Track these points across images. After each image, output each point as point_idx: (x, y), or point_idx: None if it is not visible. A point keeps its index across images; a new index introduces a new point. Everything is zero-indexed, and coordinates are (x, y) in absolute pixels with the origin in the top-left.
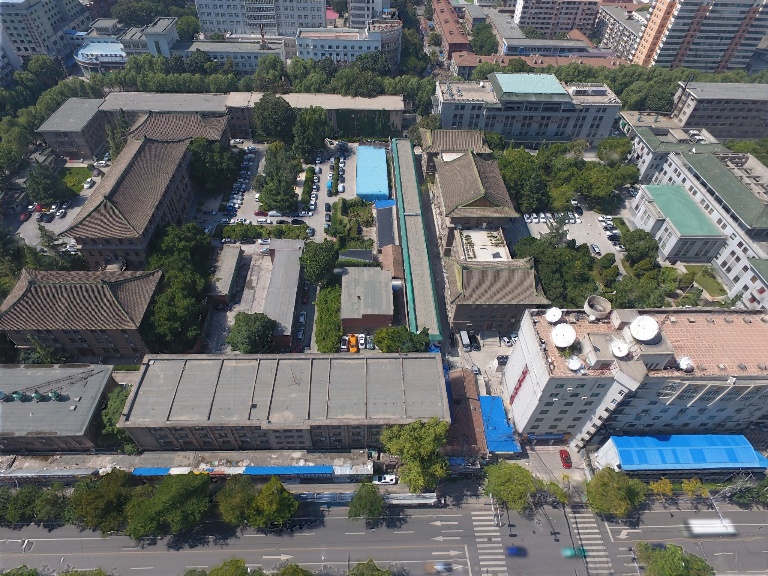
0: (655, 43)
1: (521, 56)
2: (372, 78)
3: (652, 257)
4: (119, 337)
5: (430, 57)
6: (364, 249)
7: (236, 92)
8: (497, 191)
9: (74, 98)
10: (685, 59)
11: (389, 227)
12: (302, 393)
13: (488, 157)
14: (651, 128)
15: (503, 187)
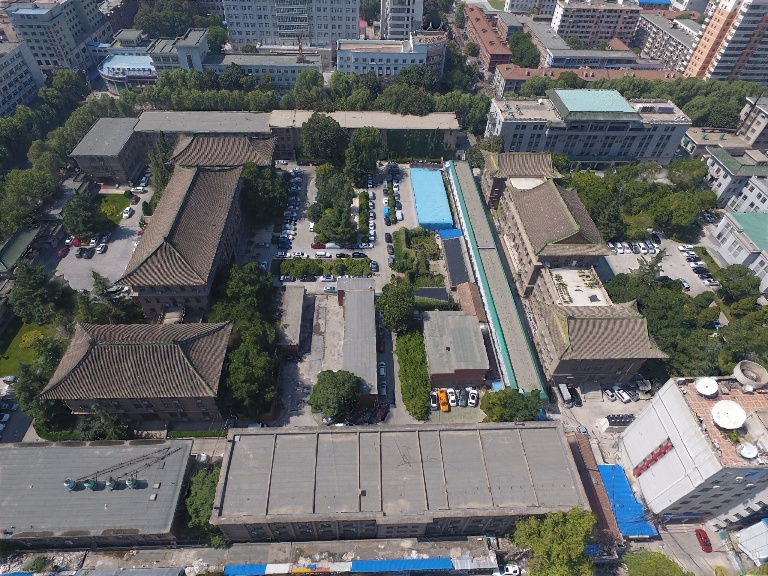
0: (711, 55)
1: (571, 69)
2: (423, 95)
3: (754, 296)
4: (190, 402)
5: None
6: (436, 287)
7: (278, 110)
8: (586, 225)
9: (106, 118)
10: (742, 71)
11: (460, 261)
12: (415, 475)
13: (557, 181)
14: (727, 149)
15: (590, 219)
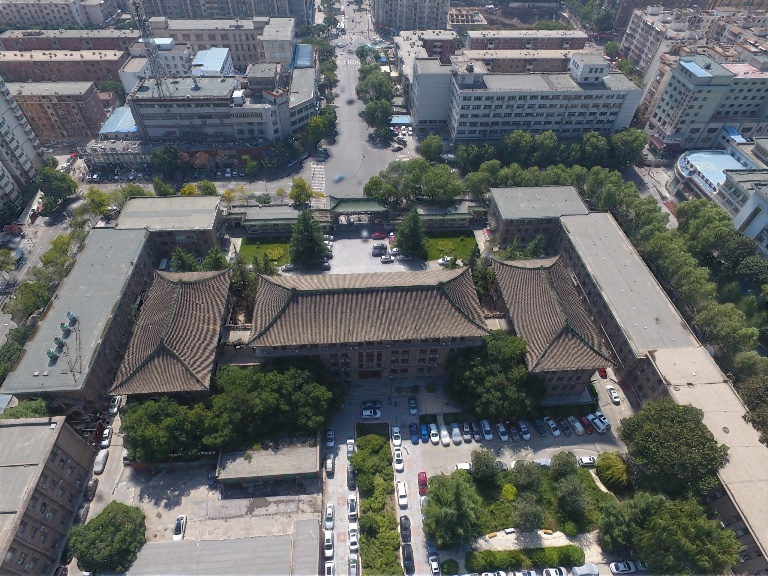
0: None
1: None
2: None
3: None
4: None
5: None
6: None
7: None
8: None
9: (575, 189)
10: None
11: None
12: None
13: None
14: None
15: None
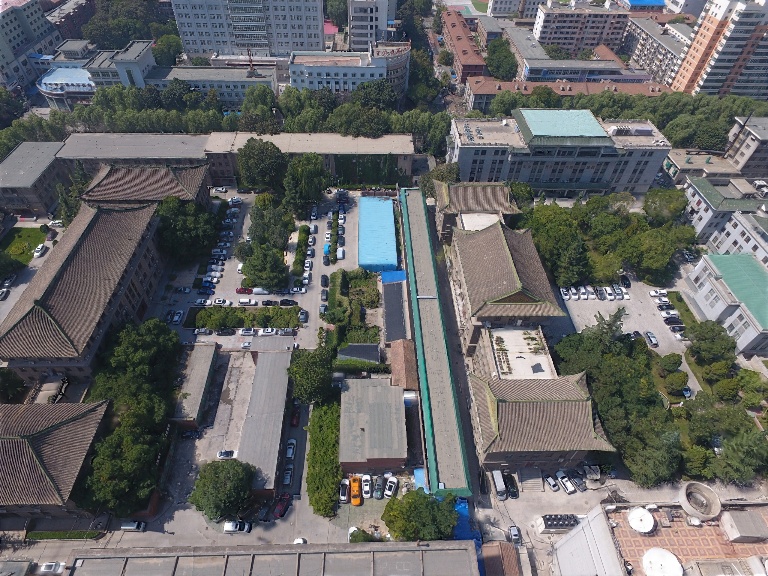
0: (700, 66)
1: (546, 82)
2: (376, 115)
3: (729, 359)
4: None
5: (441, 82)
6: (368, 343)
7: (218, 132)
8: (534, 277)
9: (29, 142)
10: (735, 85)
11: (399, 311)
12: None
13: (516, 216)
14: (709, 178)
15: (541, 269)
